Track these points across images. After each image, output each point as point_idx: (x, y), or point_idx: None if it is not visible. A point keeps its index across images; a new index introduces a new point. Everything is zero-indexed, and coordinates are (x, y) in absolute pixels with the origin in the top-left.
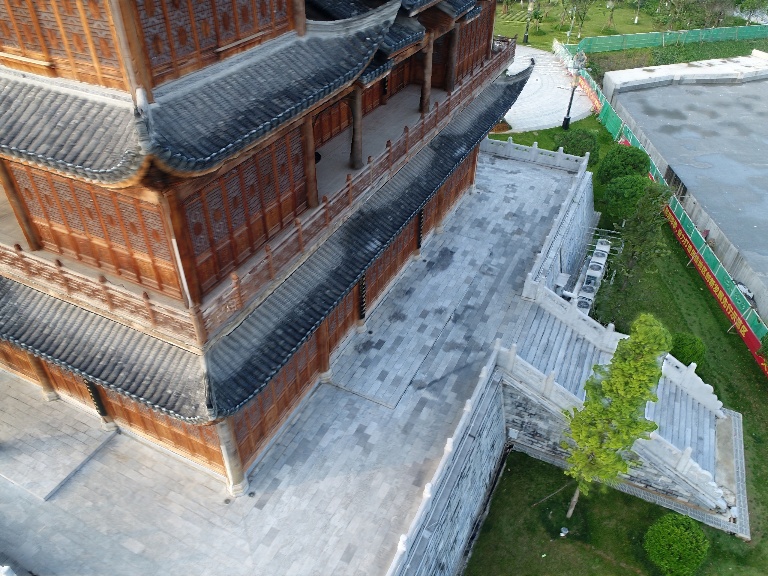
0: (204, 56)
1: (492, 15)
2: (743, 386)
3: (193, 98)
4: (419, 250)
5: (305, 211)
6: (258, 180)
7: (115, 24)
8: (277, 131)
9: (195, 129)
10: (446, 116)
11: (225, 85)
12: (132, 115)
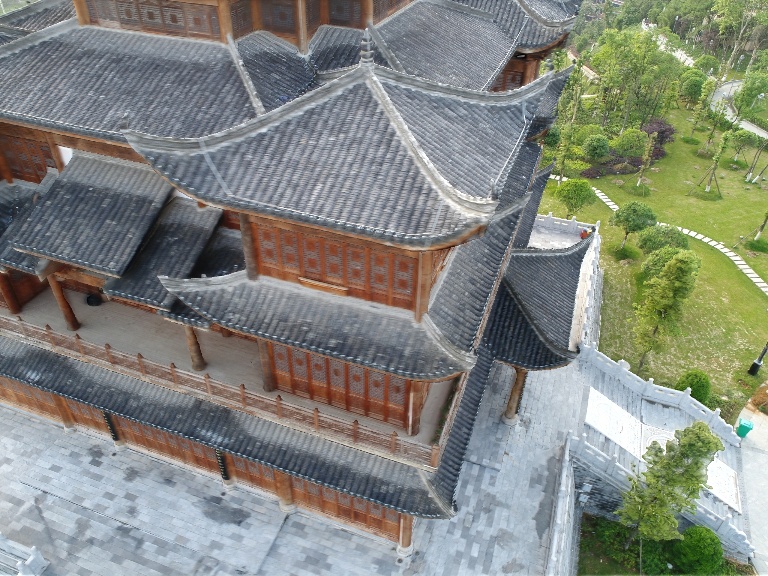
0: None
1: (410, 386)
2: None
3: None
4: (226, 481)
5: (7, 308)
6: None
7: None
8: None
9: None
10: (171, 381)
11: None
12: None
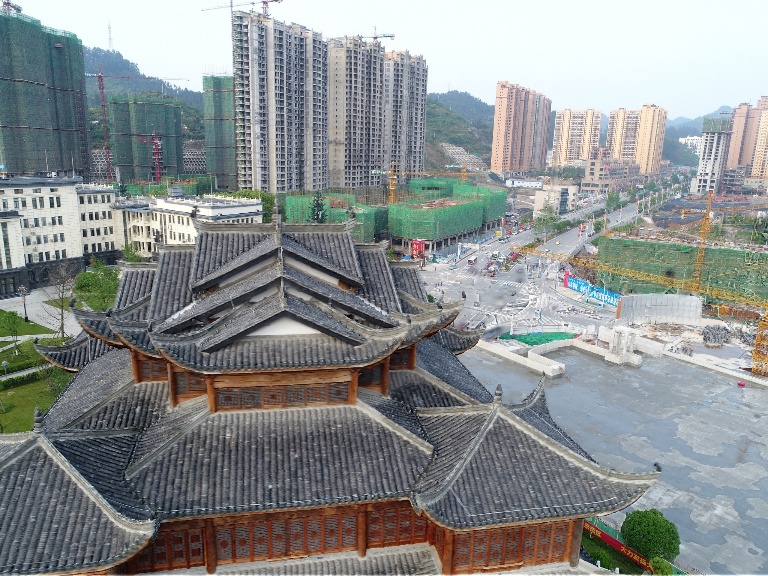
0: None
1: None
2: (625, 568)
3: None
4: None
5: None
6: None
7: (579, 536)
8: None
9: None
10: None
11: None
12: (575, 572)
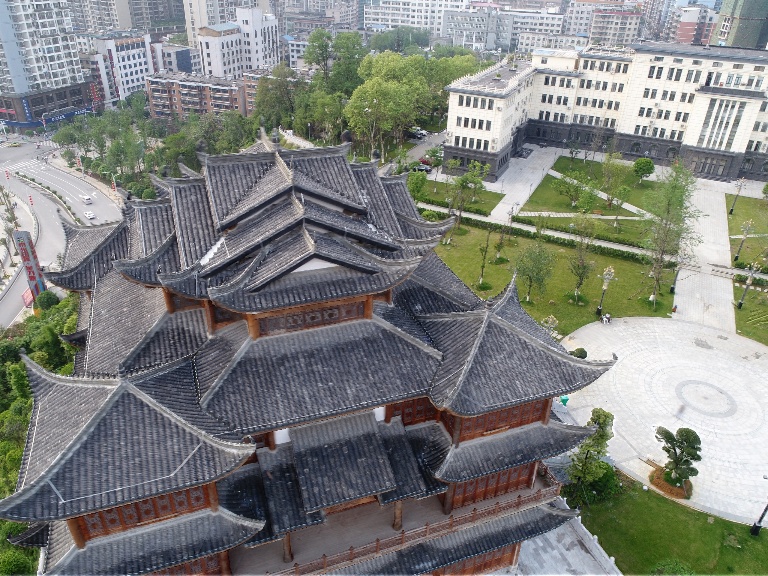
0: (129, 526)
1: None
2: None
3: (108, 547)
4: None
5: None
6: (170, 568)
7: None
8: (142, 575)
9: (91, 568)
10: (398, 545)
11: (133, 541)
12: None
